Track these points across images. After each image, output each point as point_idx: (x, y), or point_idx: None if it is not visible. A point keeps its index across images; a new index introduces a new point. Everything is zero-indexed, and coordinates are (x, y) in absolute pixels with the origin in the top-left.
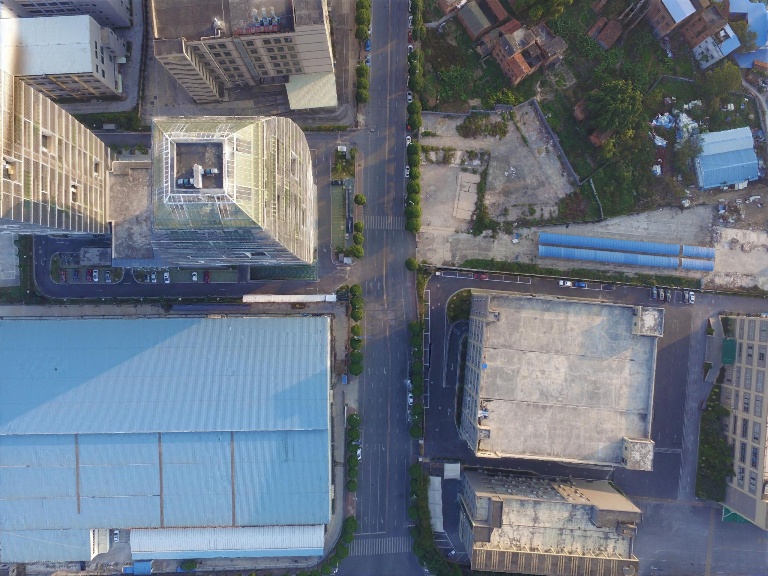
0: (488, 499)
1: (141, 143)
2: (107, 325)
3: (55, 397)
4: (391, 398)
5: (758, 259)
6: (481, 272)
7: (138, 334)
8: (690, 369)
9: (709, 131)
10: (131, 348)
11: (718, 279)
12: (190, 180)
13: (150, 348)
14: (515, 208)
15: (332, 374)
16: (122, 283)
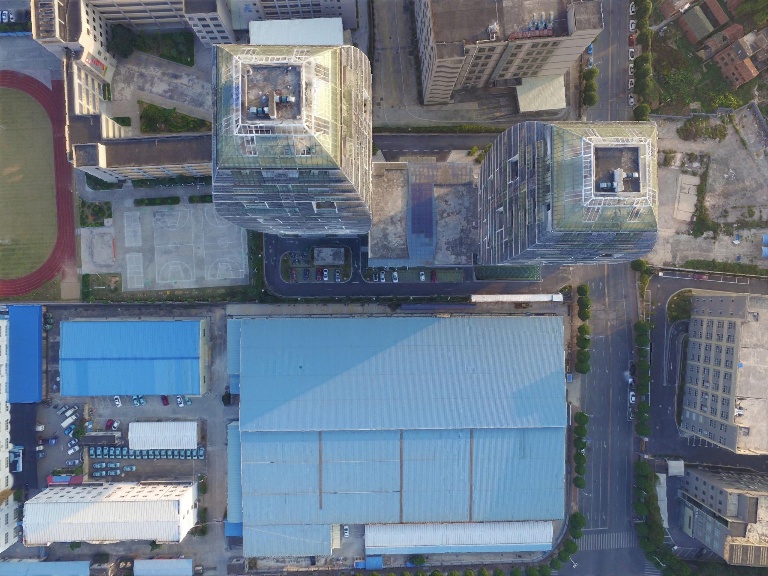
0: (738, 495)
1: None
2: (349, 324)
3: (301, 394)
4: (612, 396)
5: None
6: (701, 273)
7: (379, 333)
8: None
9: None
10: (373, 346)
11: None
12: (614, 184)
13: (391, 346)
14: (735, 210)
15: None
16: (350, 282)
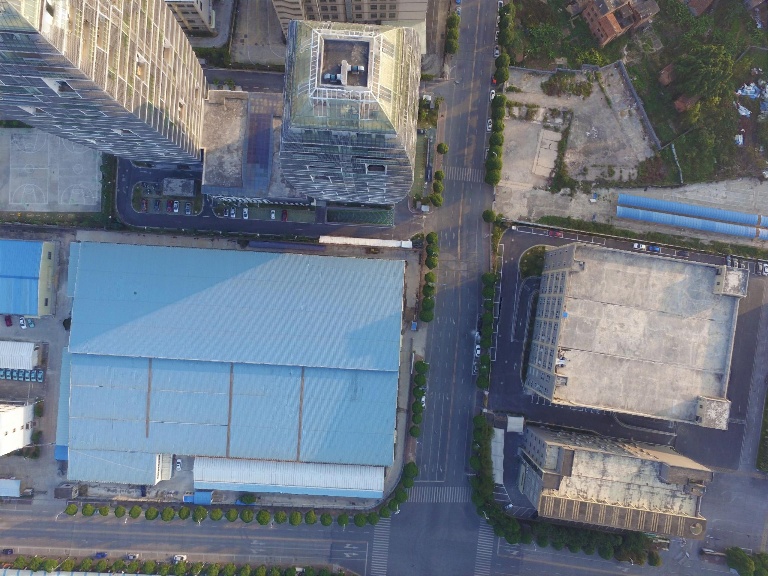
0: (558, 448)
1: None
2: (188, 253)
3: (133, 320)
4: (458, 348)
5: None
6: (556, 229)
7: (217, 264)
8: (759, 341)
9: None
10: (210, 278)
11: None
12: (337, 75)
13: (228, 279)
14: (594, 168)
15: None
16: (201, 216)
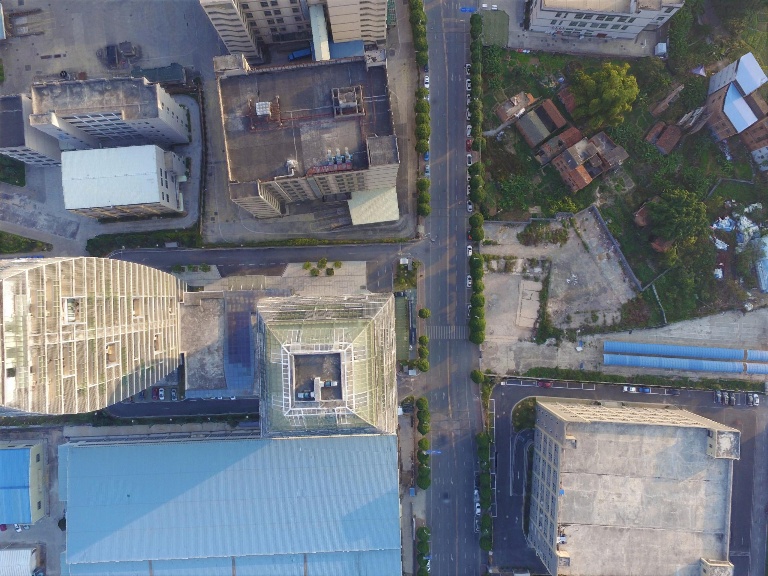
0: None
1: (203, 260)
2: (178, 449)
3: (128, 524)
4: (458, 508)
5: None
6: (545, 380)
7: (209, 457)
8: (756, 471)
9: None
10: (202, 472)
11: None
12: (311, 394)
13: (221, 471)
14: (578, 315)
15: (399, 485)
16: (188, 400)
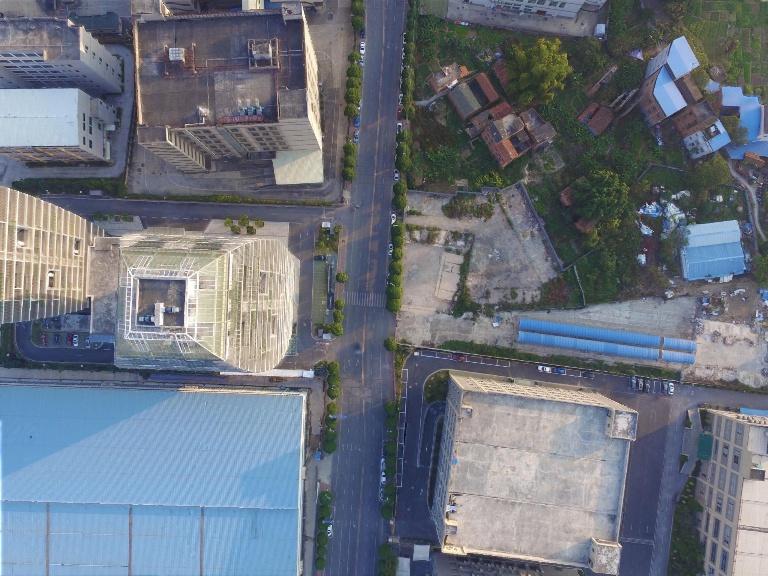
0: None
1: (127, 210)
2: (83, 394)
3: (29, 465)
4: (364, 475)
5: (740, 353)
6: (460, 354)
7: (114, 405)
8: (666, 460)
9: (696, 222)
10: (106, 419)
11: (698, 371)
12: (151, 318)
13: (125, 419)
14: (497, 291)
15: (306, 448)
16: (102, 349)
